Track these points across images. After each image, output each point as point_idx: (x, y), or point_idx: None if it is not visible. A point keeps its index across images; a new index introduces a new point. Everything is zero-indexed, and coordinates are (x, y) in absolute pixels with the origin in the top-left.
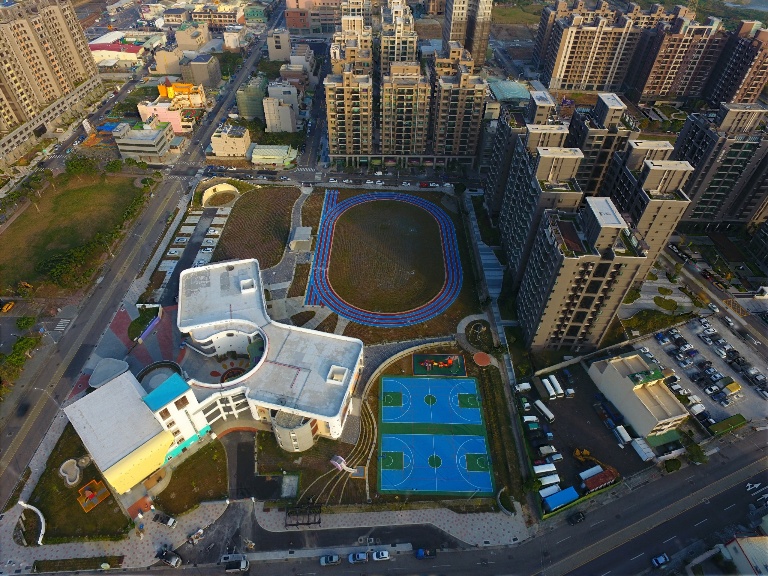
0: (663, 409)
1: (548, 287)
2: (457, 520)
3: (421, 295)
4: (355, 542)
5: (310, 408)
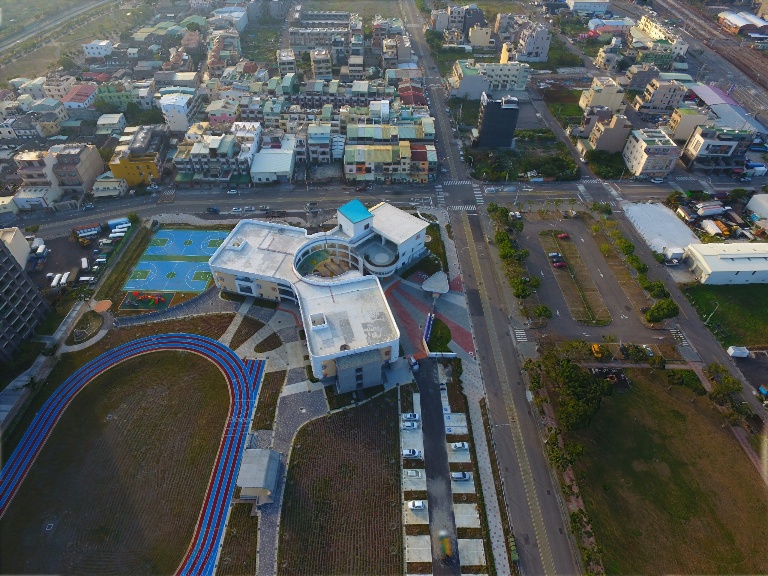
0: (2, 236)
1: (4, 249)
2: (189, 221)
3: (119, 377)
4: (250, 214)
5: (261, 228)
